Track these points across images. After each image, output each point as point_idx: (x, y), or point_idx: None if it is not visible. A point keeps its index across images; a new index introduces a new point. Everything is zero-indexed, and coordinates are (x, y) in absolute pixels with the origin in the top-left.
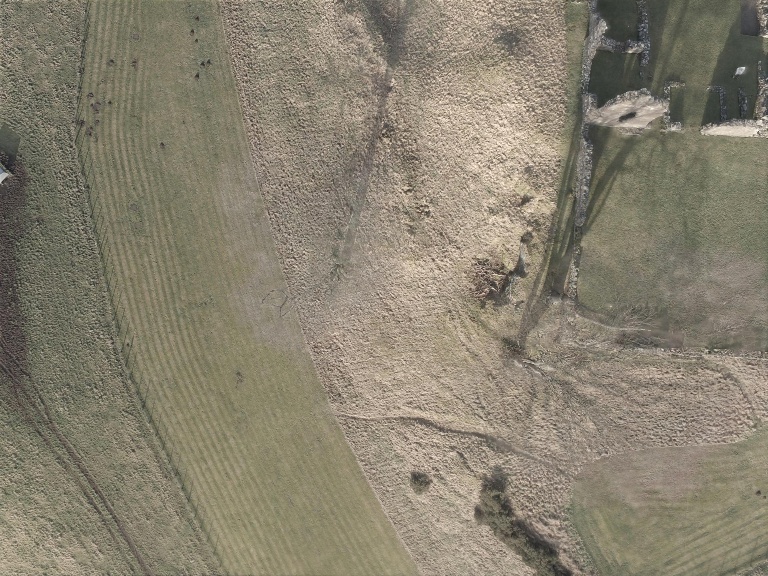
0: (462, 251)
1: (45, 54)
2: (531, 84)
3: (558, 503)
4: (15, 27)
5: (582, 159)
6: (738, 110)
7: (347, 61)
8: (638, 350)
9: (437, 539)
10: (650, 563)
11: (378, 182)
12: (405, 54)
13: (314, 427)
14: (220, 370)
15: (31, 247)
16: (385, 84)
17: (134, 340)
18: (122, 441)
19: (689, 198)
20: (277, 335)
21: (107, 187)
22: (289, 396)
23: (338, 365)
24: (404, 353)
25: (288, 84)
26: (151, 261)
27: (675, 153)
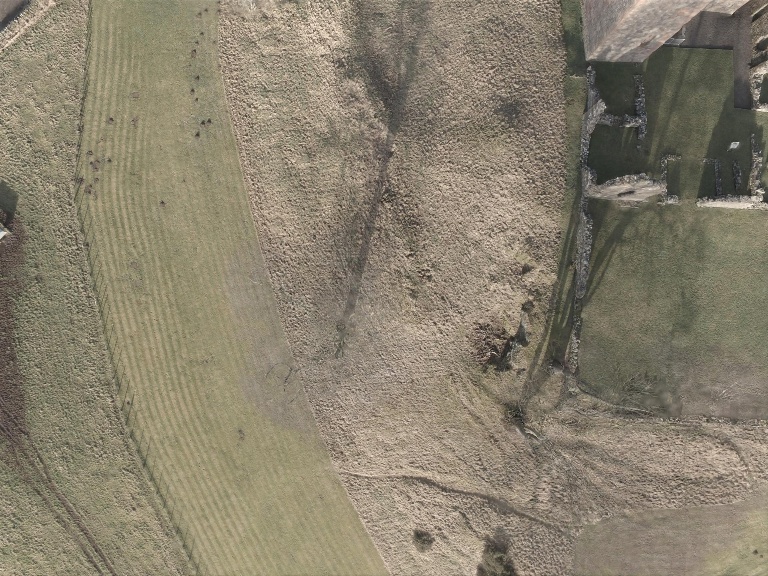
0: (464, 316)
1: (44, 112)
2: (531, 156)
3: (560, 564)
4: (13, 85)
5: (582, 233)
6: (733, 182)
7: (348, 125)
8: (638, 420)
9: None
10: None
11: (380, 245)
12: (406, 120)
13: (316, 484)
14: (221, 428)
15: (29, 305)
16: (386, 149)
17: (134, 398)
18: (122, 499)
19: (686, 268)
20: (279, 393)
21: (107, 245)
22: (291, 454)
23: (340, 423)
24: (406, 414)
25: (289, 145)
26: (151, 319)
27: (672, 225)
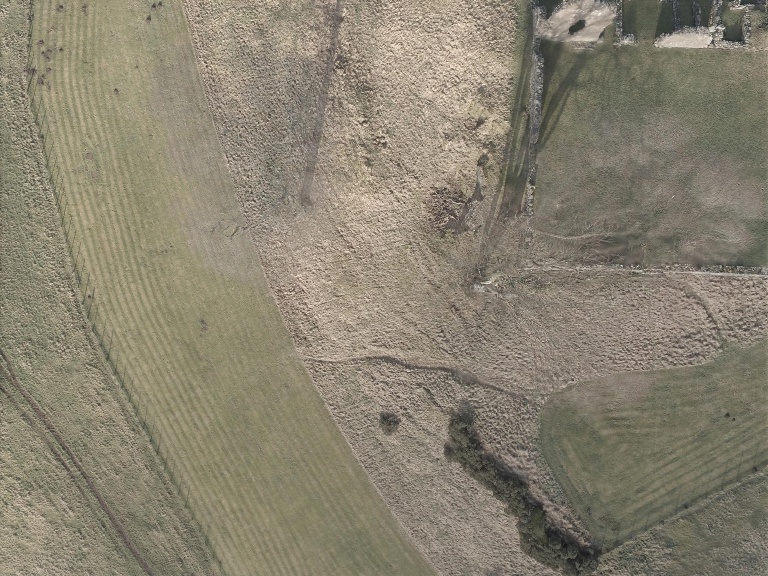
0: (420, 181)
1: None
2: (481, 2)
3: (526, 433)
4: None
5: (534, 74)
6: (692, 21)
7: None
8: (597, 267)
9: (409, 481)
10: (621, 491)
11: (334, 116)
12: None
13: (281, 373)
14: (184, 319)
15: None
16: (337, 14)
17: (95, 291)
18: (87, 395)
19: (645, 113)
20: (240, 280)
21: (62, 136)
22: (254, 342)
23: (302, 308)
24: (367, 290)
25: (241, 22)
26: (109, 210)
27: (629, 67)
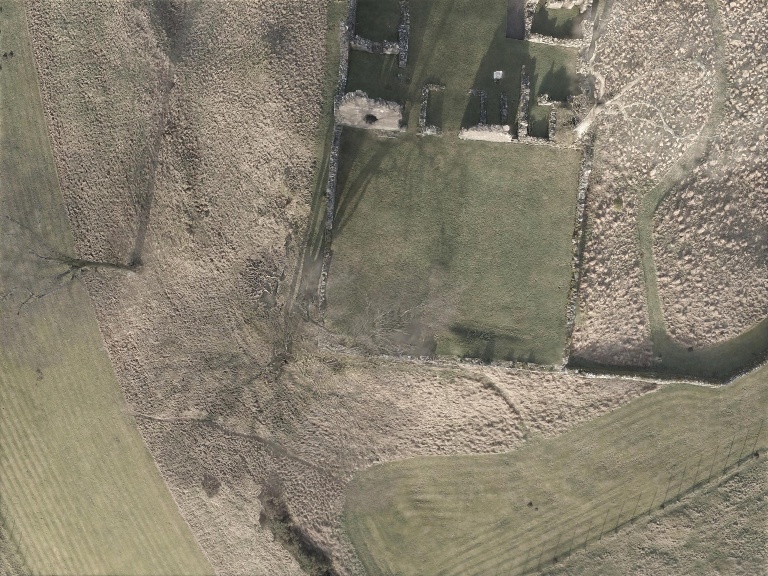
0: (237, 252)
1: None
2: (291, 83)
3: (330, 510)
4: None
5: None
6: (499, 115)
7: (135, 56)
8: (383, 357)
9: (232, 543)
10: (424, 573)
11: (162, 180)
12: (188, 50)
13: (112, 427)
14: (20, 367)
15: None
16: (169, 80)
17: None
18: None
19: (448, 203)
20: (76, 332)
21: None
22: (88, 395)
23: (134, 364)
24: (190, 354)
25: (86, 78)
26: None
27: (433, 157)
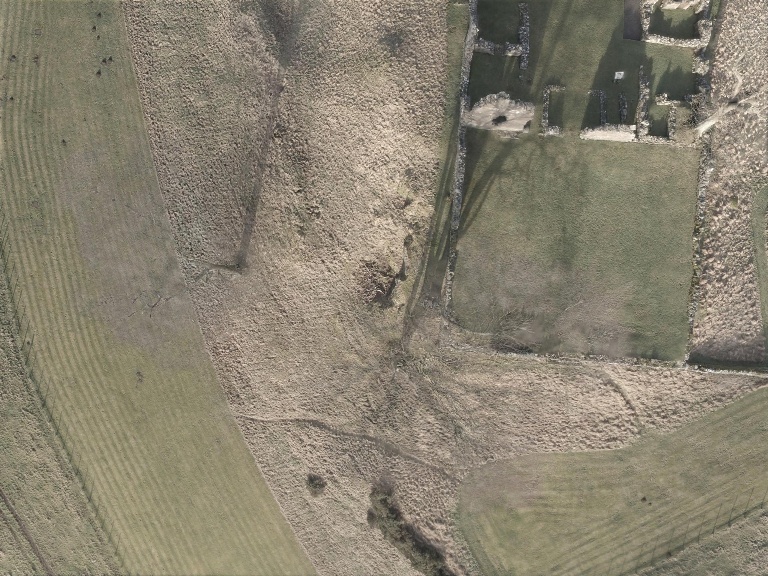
0: (350, 253)
1: None
2: (412, 86)
3: (444, 507)
4: None
5: (457, 162)
6: (618, 115)
7: (242, 60)
8: (511, 355)
9: (334, 542)
10: (537, 569)
11: (271, 182)
12: (297, 54)
13: (213, 428)
14: (120, 369)
15: None
16: (277, 84)
17: (34, 338)
18: (22, 440)
19: (568, 203)
20: (177, 335)
21: (8, 184)
22: (189, 396)
23: (236, 366)
24: (297, 355)
25: (187, 82)
26: (52, 259)
27: (554, 157)
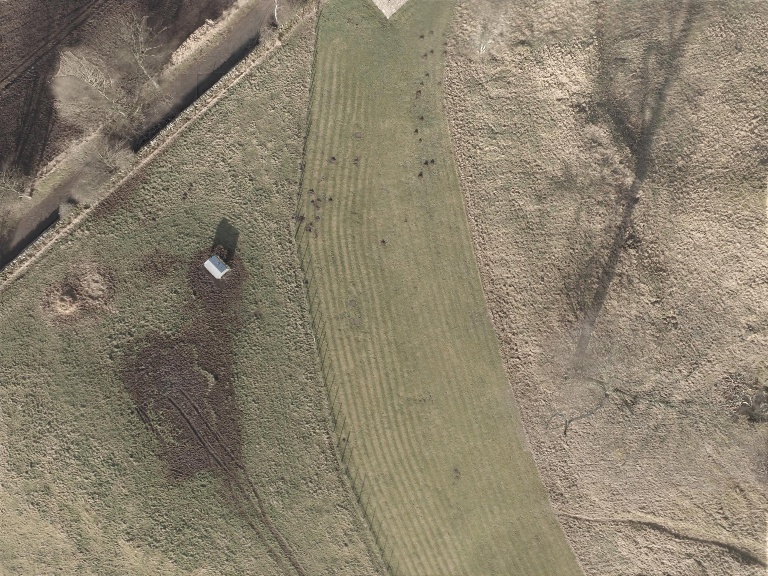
0: (714, 365)
1: (266, 150)
2: None
3: None
4: (236, 123)
5: None
6: None
7: (588, 170)
8: None
9: None
10: None
11: (620, 291)
12: (653, 166)
13: (533, 525)
14: (437, 466)
15: (248, 341)
16: (631, 195)
17: (350, 435)
18: (335, 535)
19: None
20: (498, 433)
21: (326, 283)
22: (508, 494)
23: (562, 465)
24: (640, 459)
25: (517, 187)
26: (369, 357)
27: None
